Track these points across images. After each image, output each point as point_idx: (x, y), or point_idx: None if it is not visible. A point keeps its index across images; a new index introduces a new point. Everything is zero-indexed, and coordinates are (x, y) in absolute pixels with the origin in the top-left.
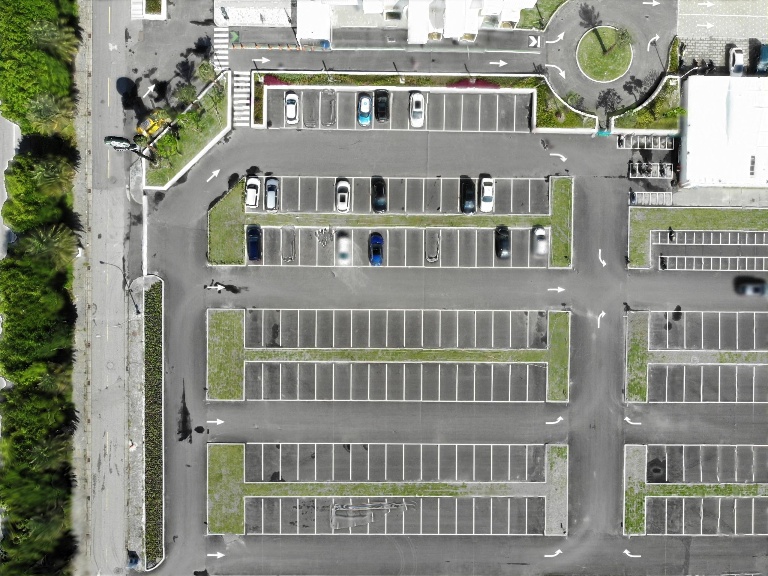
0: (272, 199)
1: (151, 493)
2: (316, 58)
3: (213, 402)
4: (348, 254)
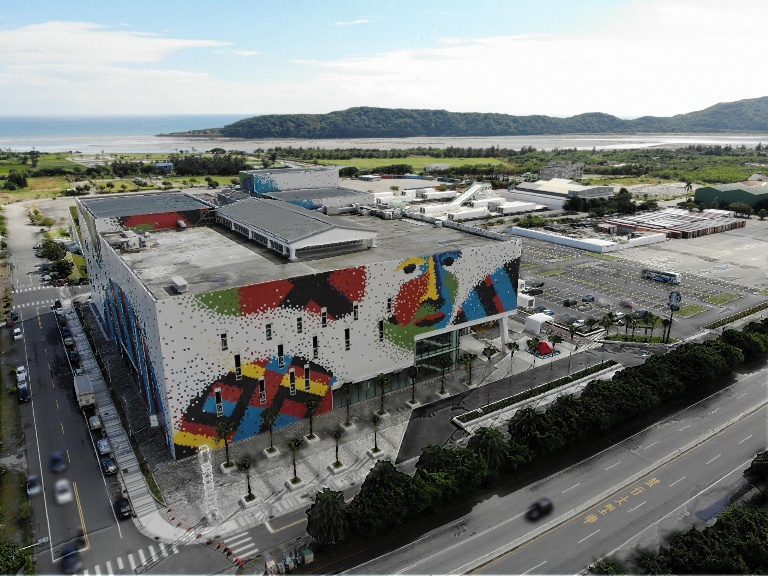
0: (619, 313)
1: (763, 307)
2: (550, 327)
3: (708, 308)
4: (602, 303)
